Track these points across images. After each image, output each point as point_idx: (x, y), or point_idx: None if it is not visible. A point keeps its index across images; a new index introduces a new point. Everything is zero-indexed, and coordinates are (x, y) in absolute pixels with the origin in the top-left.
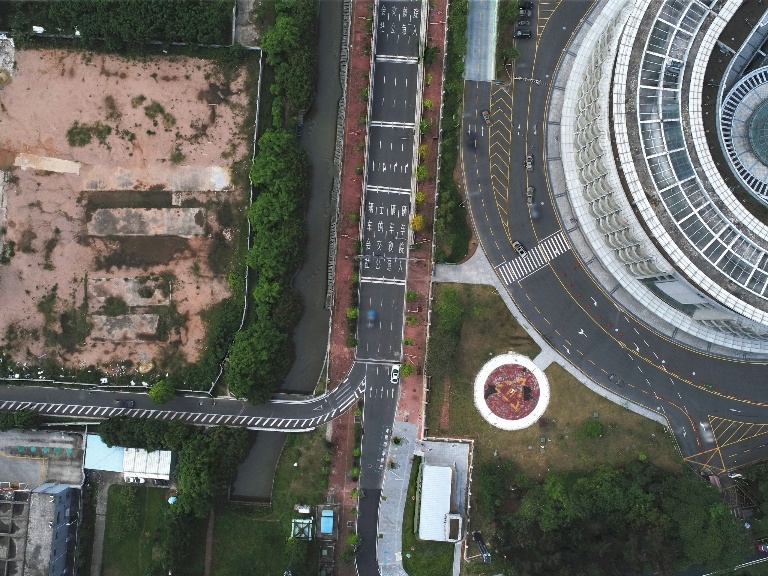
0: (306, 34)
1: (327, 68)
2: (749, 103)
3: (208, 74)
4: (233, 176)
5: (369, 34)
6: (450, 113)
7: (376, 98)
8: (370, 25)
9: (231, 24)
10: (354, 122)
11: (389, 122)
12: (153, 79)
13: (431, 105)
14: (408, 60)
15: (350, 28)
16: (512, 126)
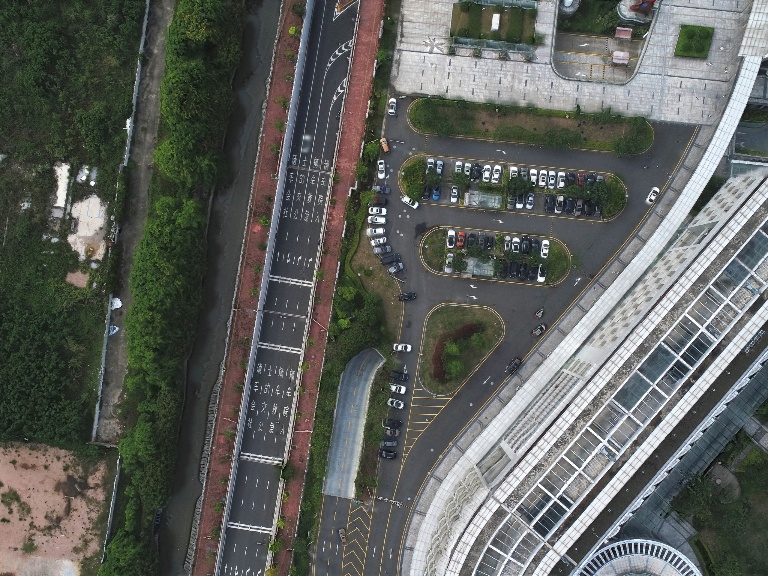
0: (165, 441)
1: (186, 470)
2: (603, 575)
3: (67, 465)
4: (82, 572)
5: (233, 437)
6: (305, 529)
7: (235, 499)
8: (235, 428)
9: (93, 420)
10: (209, 526)
11: (246, 525)
12: (12, 465)
13: (284, 526)
14: (272, 461)
15: (214, 429)
16: (368, 547)
